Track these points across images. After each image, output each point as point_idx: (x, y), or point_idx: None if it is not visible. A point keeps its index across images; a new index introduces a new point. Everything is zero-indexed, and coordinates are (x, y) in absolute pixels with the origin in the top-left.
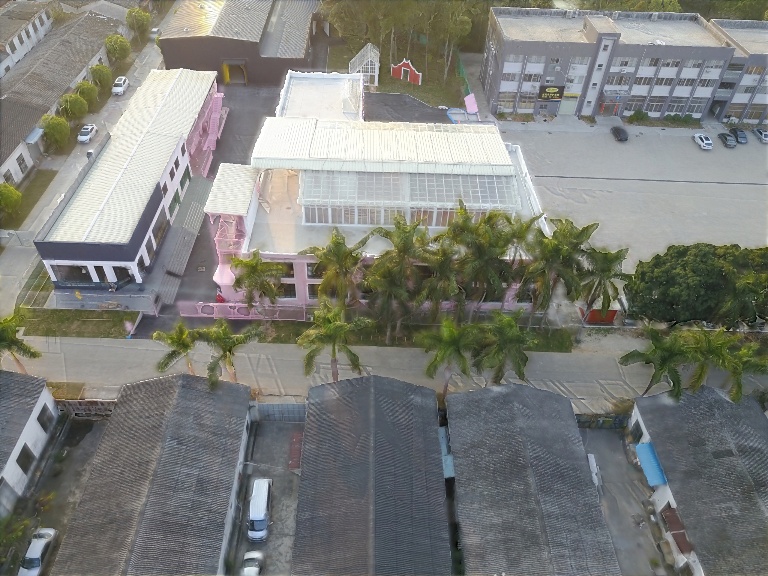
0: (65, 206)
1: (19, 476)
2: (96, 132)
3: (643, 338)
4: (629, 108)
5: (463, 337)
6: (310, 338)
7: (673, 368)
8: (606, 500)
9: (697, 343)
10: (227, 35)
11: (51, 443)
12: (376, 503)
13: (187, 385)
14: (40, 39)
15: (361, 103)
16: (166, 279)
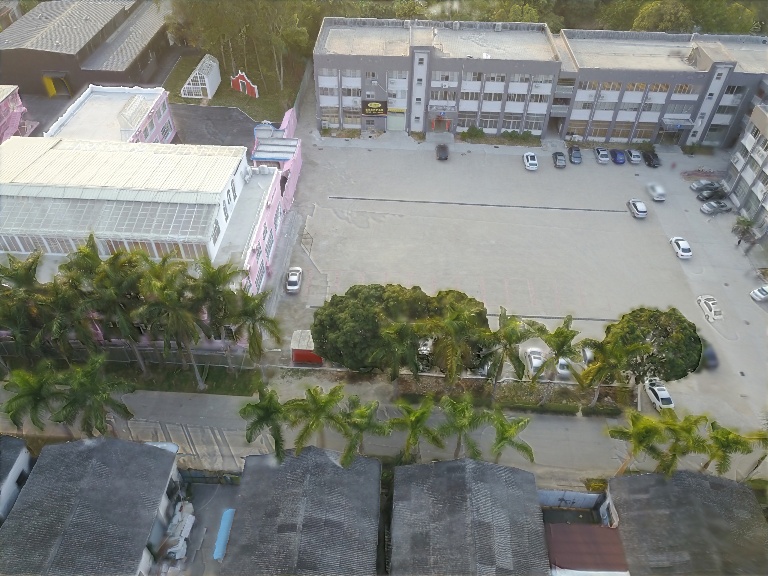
0: None
1: None
2: None
3: (340, 382)
4: (462, 124)
5: (43, 386)
6: None
7: (278, 426)
8: (192, 568)
9: None
10: (44, 47)
11: None
12: None
13: None
14: None
15: (142, 120)
16: None
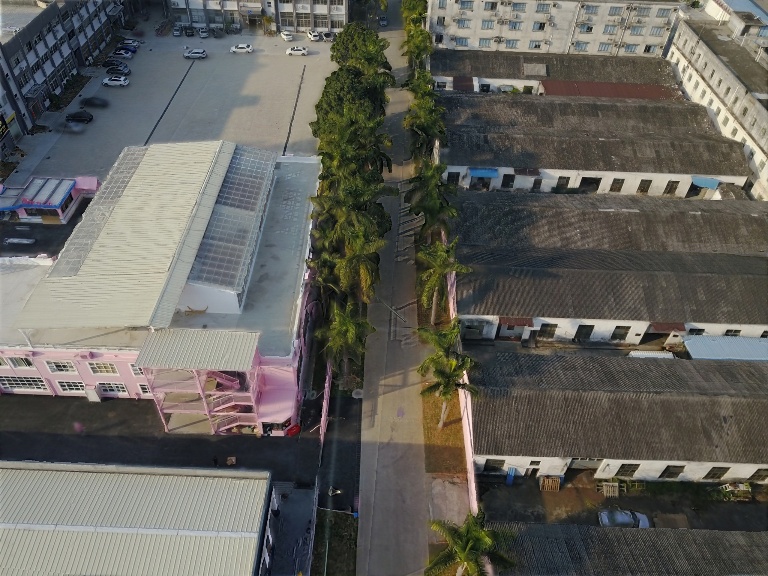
0: None
1: None
2: None
3: None
4: (44, 99)
5: None
6: None
7: None
8: None
9: (419, 118)
10: None
11: None
12: None
13: (482, 383)
14: None
15: None
16: None
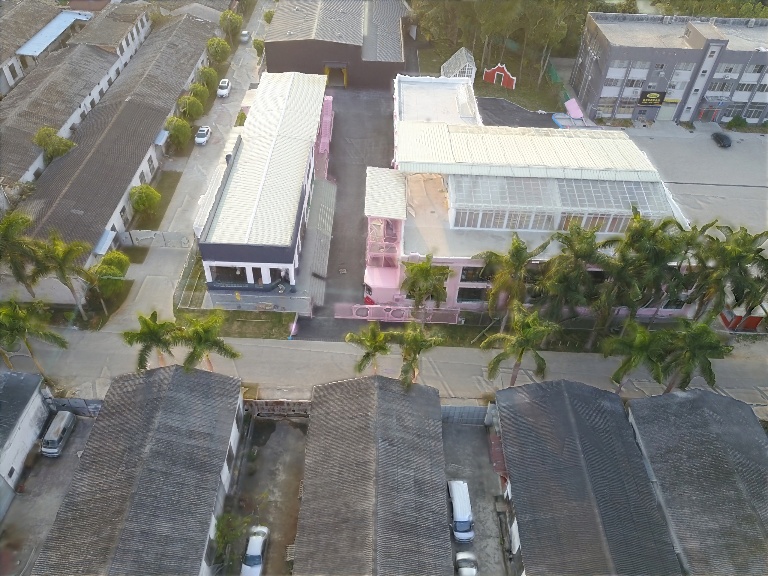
0: (217, 208)
1: (227, 474)
2: (210, 134)
3: None
4: (728, 114)
5: (653, 343)
6: (501, 342)
7: None
8: None
9: None
10: (331, 39)
11: (242, 442)
12: (599, 506)
13: (383, 387)
14: (141, 41)
15: (477, 108)
16: (313, 281)
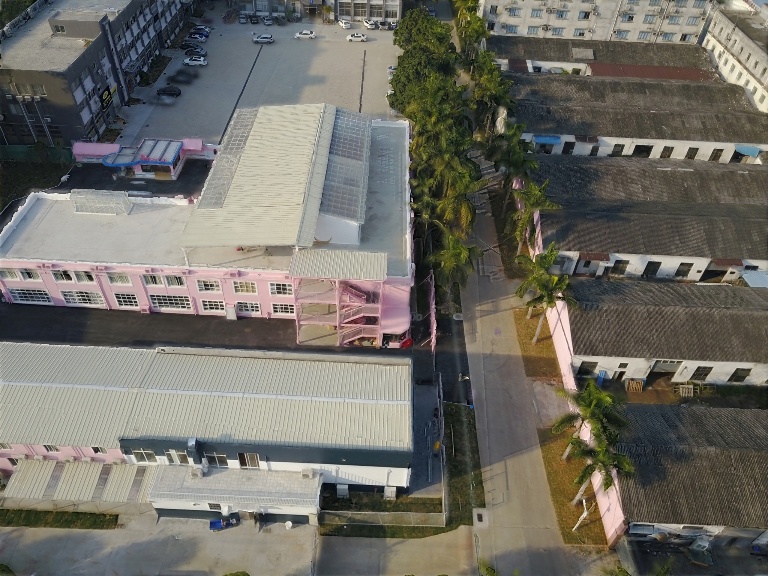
0: None
1: None
2: None
3: None
4: (135, 75)
5: None
6: None
7: None
8: None
9: (490, 90)
10: None
11: None
12: None
13: (576, 299)
14: None
15: None
16: None
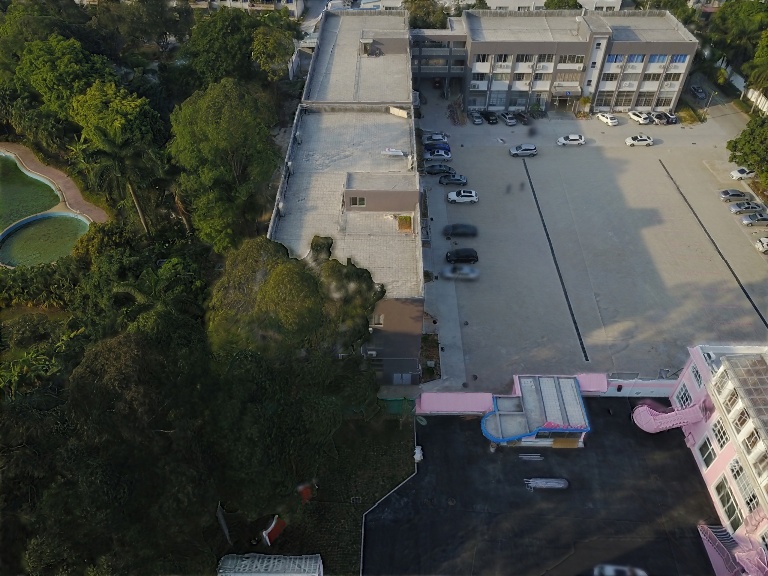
0: None
1: None
2: None
3: None
4: None
5: None
6: None
7: None
8: None
9: None
10: None
11: None
12: None
13: None
14: None
15: None
16: None
